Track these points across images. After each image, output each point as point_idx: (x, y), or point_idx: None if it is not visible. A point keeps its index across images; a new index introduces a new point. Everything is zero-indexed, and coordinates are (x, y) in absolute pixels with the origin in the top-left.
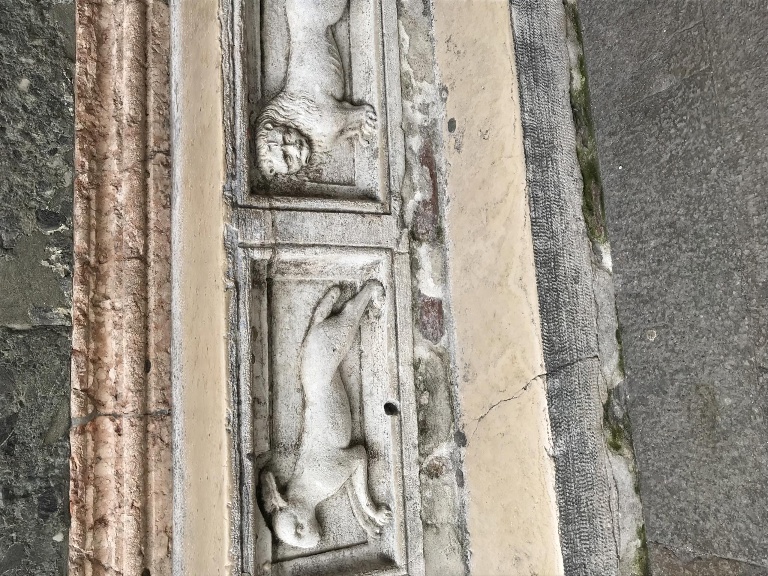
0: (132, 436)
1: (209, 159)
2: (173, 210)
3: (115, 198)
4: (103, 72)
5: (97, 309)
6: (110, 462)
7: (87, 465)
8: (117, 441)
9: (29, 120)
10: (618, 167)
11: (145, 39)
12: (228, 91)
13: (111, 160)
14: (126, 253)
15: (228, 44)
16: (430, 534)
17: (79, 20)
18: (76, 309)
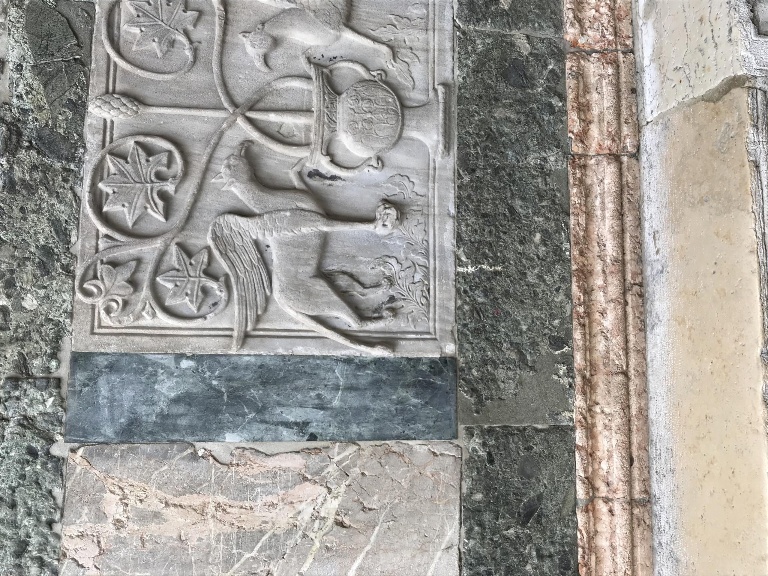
0: (624, 517)
1: (735, 320)
2: (649, 333)
3: (601, 323)
4: (588, 220)
5: (591, 412)
6: (605, 535)
7: (590, 536)
8: (611, 519)
9: (542, 265)
10: None
11: (621, 191)
12: (763, 272)
13: (597, 292)
14: (613, 368)
15: (761, 232)
16: None
17: (573, 182)
18: (579, 413)
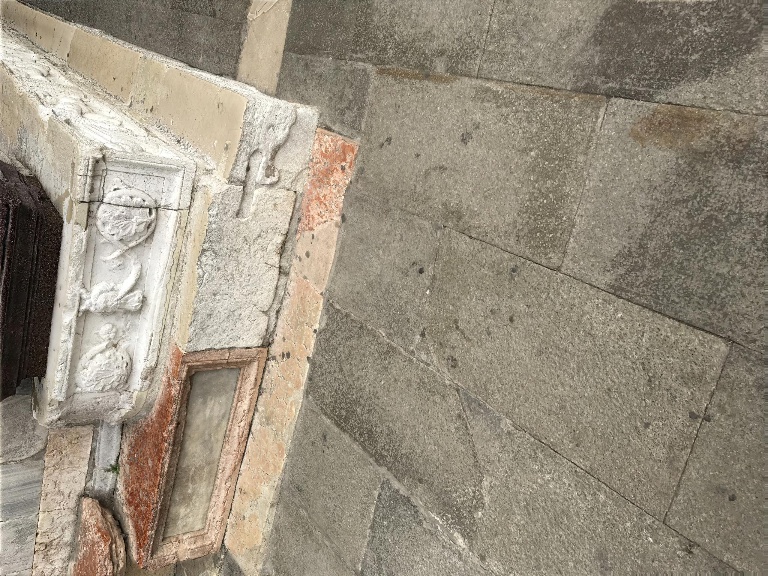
0: None
1: None
2: None
3: None
4: None
5: None
6: None
7: None
8: None
9: None
10: (45, 5)
11: None
12: None
13: None
14: None
15: None
16: (19, 38)
17: None
18: None
